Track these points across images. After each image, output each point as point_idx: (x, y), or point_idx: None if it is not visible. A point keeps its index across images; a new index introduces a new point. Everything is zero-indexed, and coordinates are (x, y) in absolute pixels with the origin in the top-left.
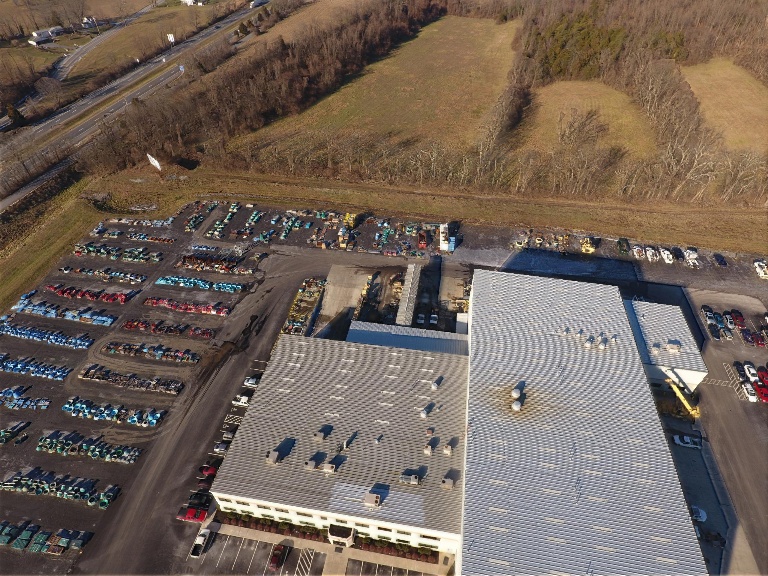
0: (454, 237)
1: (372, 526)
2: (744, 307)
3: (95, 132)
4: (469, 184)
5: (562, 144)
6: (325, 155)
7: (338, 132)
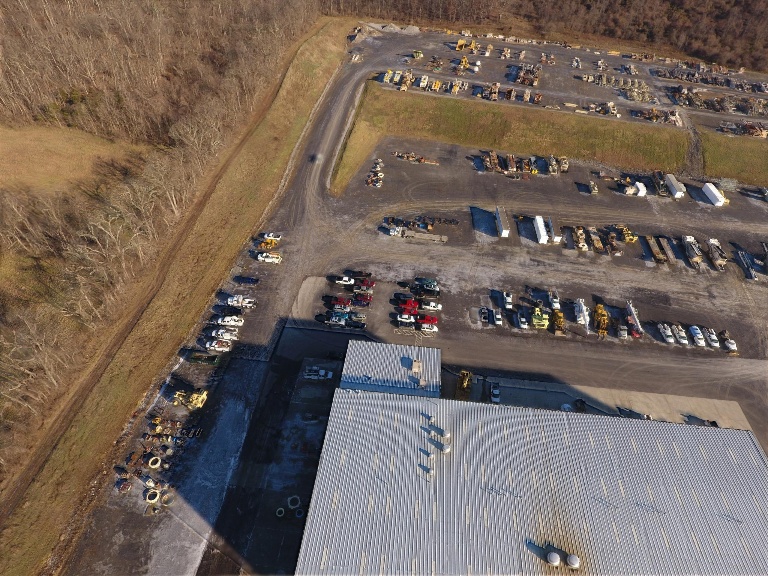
0: None
1: None
2: (319, 290)
3: None
4: None
5: None
6: None
7: None
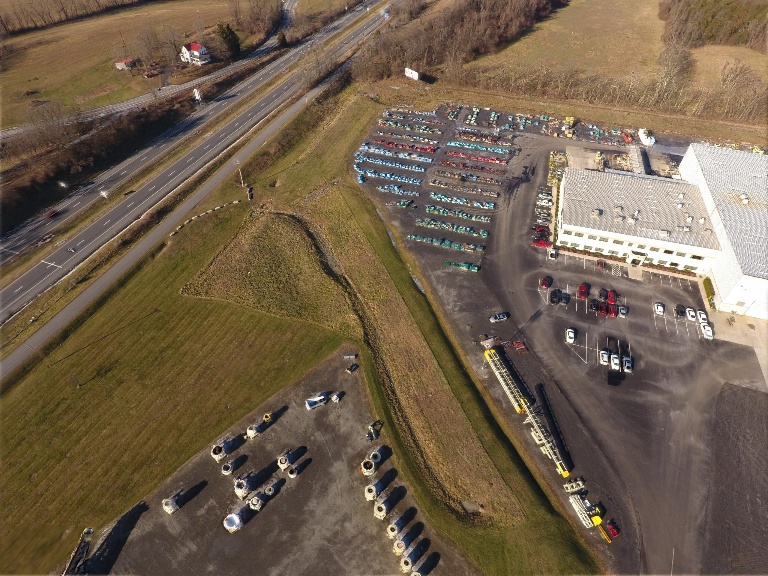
0: (653, 137)
1: (661, 249)
2: None
3: (342, 56)
4: (656, 106)
5: (723, 87)
6: (531, 82)
7: (534, 68)
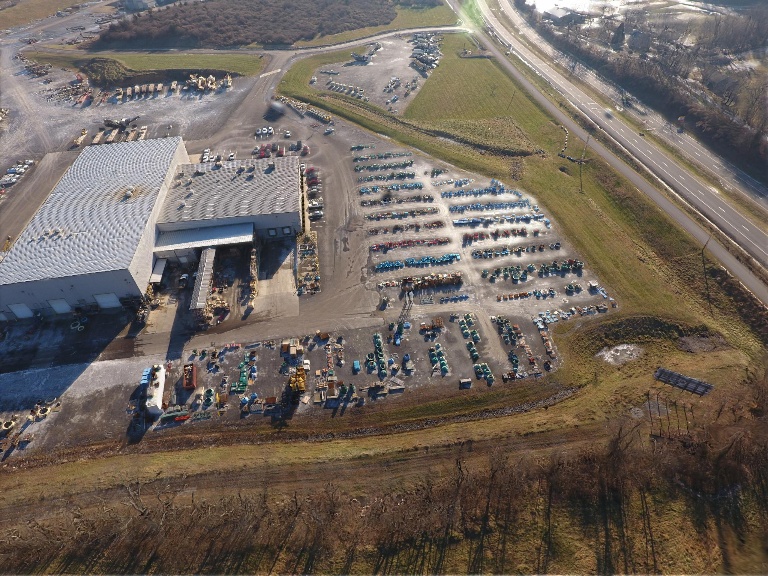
0: None
1: None
2: None
3: None
4: None
5: None
6: None
7: None
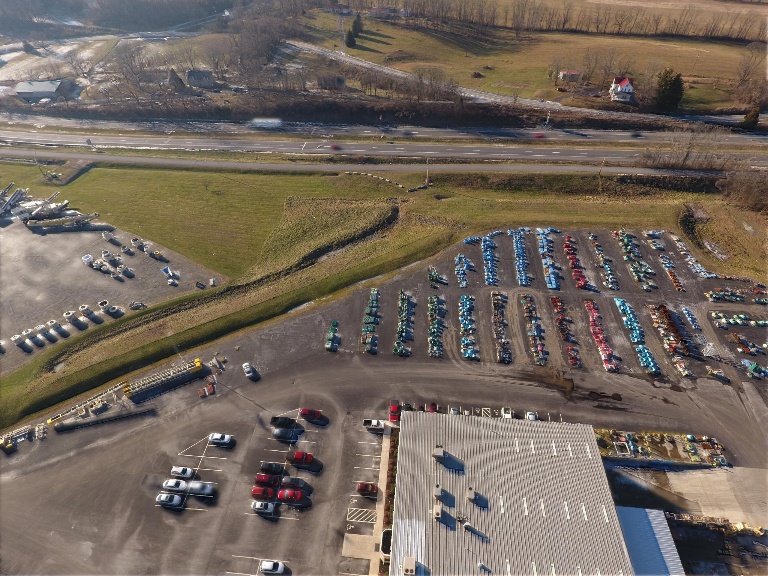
0: None
1: None
2: None
3: None
4: None
5: None
6: None
7: None
